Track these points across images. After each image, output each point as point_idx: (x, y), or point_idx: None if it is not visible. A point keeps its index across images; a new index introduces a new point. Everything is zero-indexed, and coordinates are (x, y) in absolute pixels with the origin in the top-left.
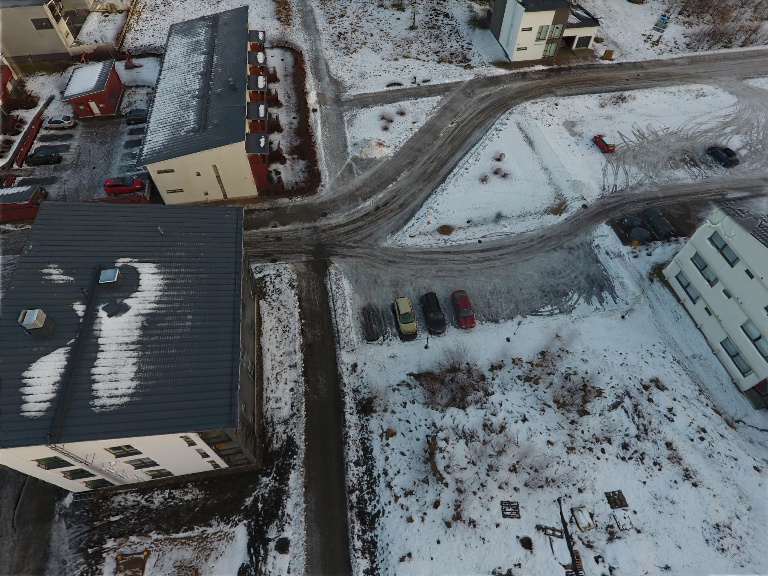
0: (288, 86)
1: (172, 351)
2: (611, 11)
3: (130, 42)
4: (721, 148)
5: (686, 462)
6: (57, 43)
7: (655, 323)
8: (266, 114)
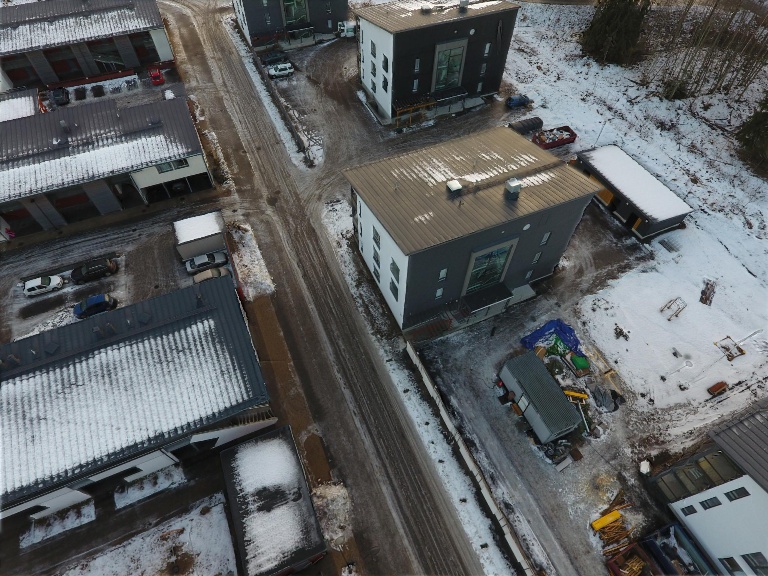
0: None
1: None
2: None
3: None
4: None
5: None
6: None
7: None
8: None
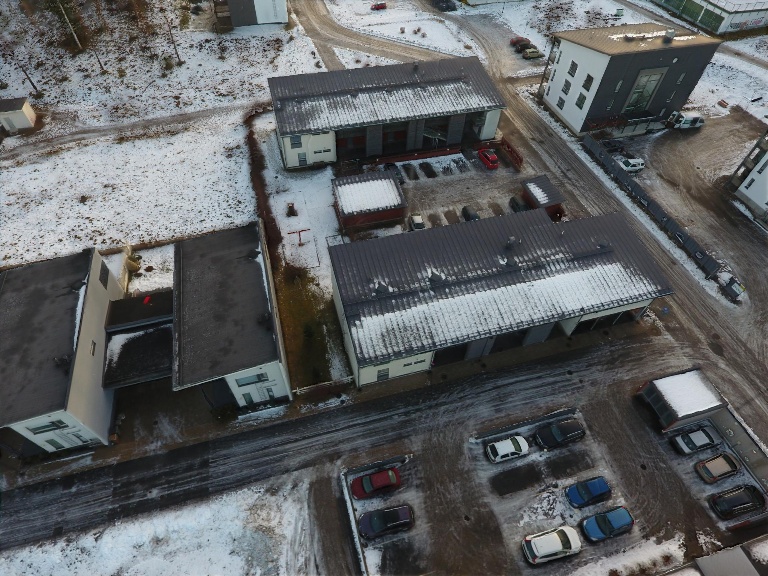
0: None
1: None
2: None
3: None
4: None
5: (566, 2)
6: None
7: (501, 8)
8: None
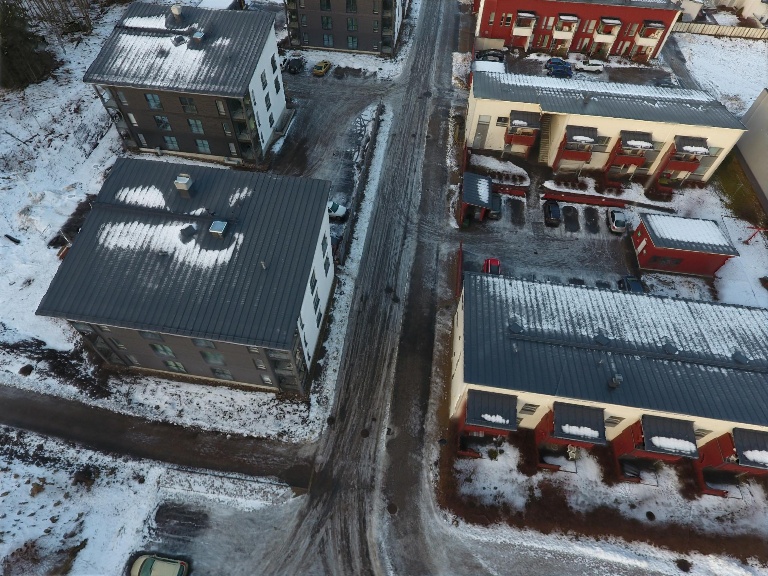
0: (762, 525)
1: (127, 272)
2: None
3: None
4: None
5: None
6: None
7: None
8: (571, 436)
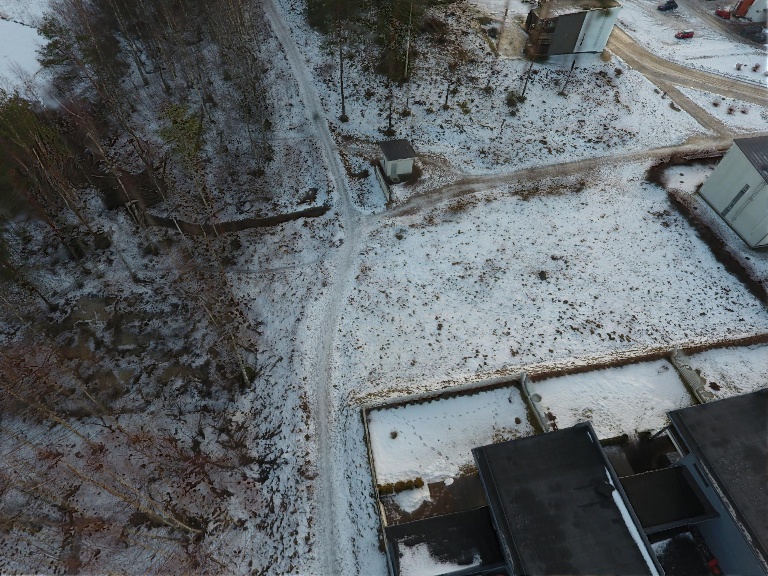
0: None
1: None
2: (495, 4)
3: (749, 333)
4: (664, 4)
5: None
6: None
7: None
8: None
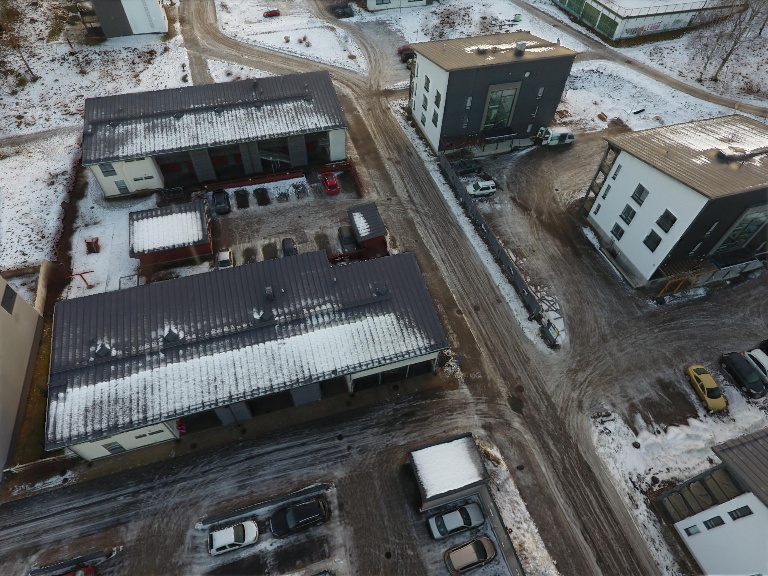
0: None
1: None
2: None
3: None
4: None
5: (465, 7)
6: (27, 313)
7: None
8: None
